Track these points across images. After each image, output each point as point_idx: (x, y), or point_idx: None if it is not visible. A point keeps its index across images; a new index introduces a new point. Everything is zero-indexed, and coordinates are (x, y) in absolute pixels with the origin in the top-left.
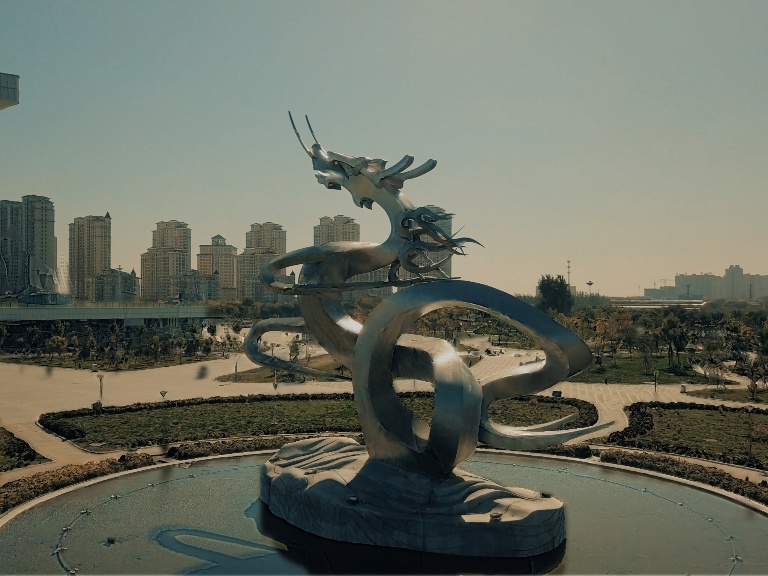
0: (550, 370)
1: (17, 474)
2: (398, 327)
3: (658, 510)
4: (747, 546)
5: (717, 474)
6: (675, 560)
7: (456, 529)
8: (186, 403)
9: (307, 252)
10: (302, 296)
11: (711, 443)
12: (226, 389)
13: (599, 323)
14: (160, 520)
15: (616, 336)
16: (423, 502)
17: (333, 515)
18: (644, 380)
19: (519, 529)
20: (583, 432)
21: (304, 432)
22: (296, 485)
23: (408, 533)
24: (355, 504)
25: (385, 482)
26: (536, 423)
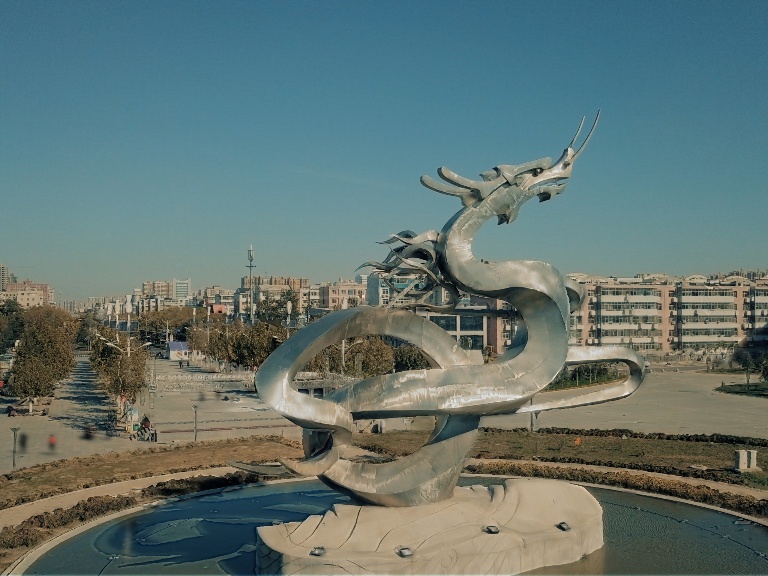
0: None
1: (701, 483)
2: None
3: None
4: None
5: None
6: None
7: None
8: None
9: None
10: None
11: None
12: None
13: None
14: None
15: None
16: None
17: None
18: None
19: None
20: None
21: None
22: None
23: None
24: None
25: None
26: None
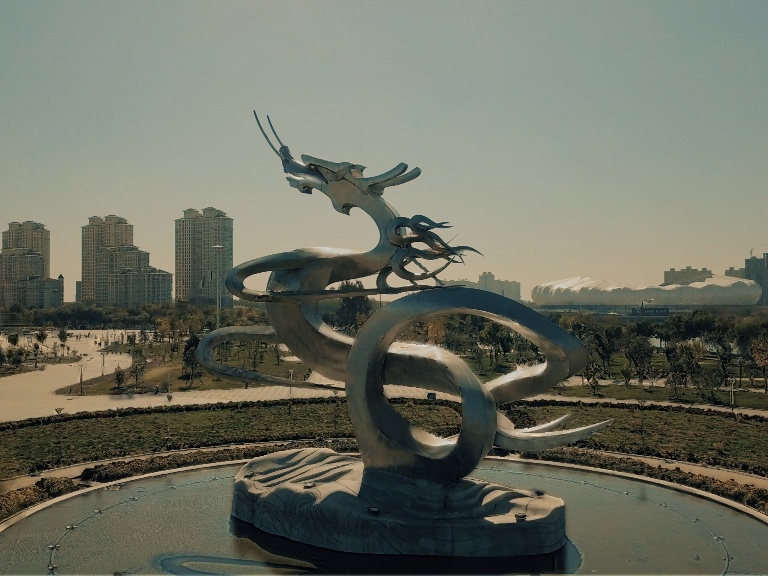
0: (550, 373)
1: None
2: (393, 334)
3: (612, 500)
4: (715, 526)
5: (637, 464)
6: (670, 544)
7: (486, 532)
8: (52, 420)
9: (284, 258)
10: (275, 303)
11: (599, 436)
12: (79, 403)
13: (432, 327)
14: (147, 549)
15: (444, 339)
16: (439, 508)
17: (354, 528)
18: (485, 380)
19: (543, 527)
20: (586, 431)
21: (210, 445)
22: (299, 500)
23: (435, 539)
24: (377, 515)
25: (393, 490)
26: (428, 425)
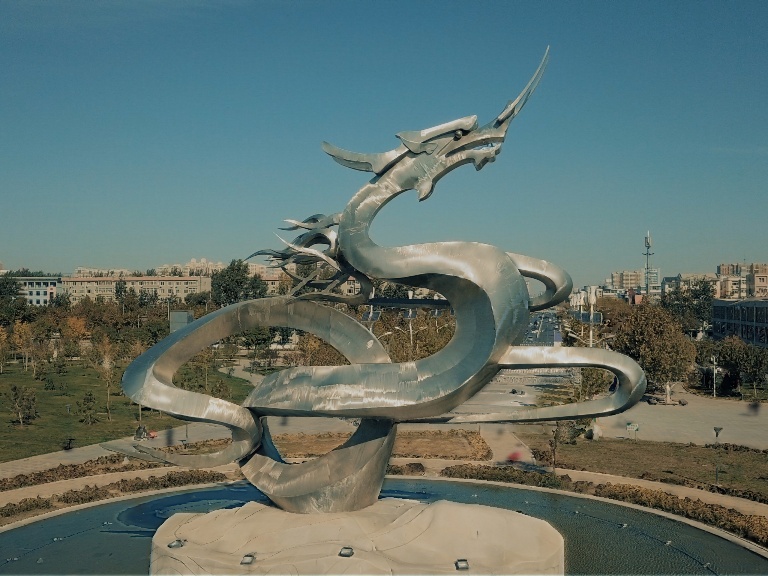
0: None
1: None
2: None
3: None
4: None
5: None
6: None
7: None
8: None
9: None
10: None
11: None
12: None
13: None
14: None
15: None
16: None
17: None
18: None
19: None
20: None
21: None
22: None
23: None
24: None
25: None
26: None
